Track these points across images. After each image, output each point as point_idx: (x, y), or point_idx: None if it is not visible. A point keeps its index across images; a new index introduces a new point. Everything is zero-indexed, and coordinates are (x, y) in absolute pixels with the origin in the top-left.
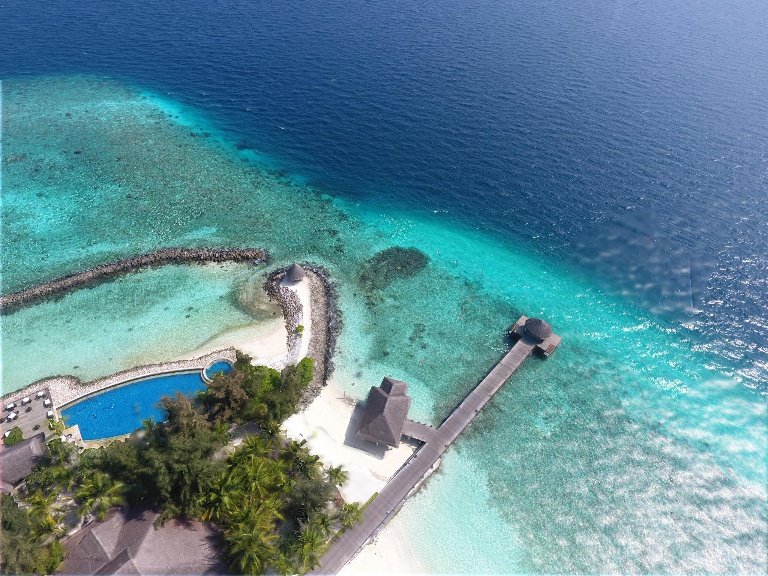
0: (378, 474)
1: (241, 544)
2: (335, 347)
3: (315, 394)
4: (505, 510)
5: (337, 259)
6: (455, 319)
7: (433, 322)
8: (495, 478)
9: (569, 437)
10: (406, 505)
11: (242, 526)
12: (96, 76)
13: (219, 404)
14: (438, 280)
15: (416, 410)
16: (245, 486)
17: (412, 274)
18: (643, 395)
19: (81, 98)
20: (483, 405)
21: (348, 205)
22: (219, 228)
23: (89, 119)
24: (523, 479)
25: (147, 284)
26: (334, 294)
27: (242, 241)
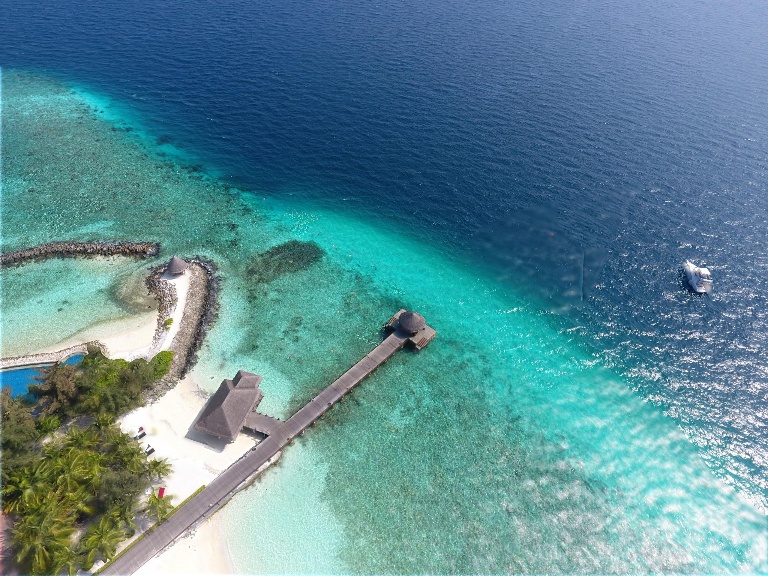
0: (212, 467)
1: (21, 536)
2: (204, 340)
3: (169, 387)
4: (337, 503)
5: (229, 253)
6: (335, 313)
7: (312, 316)
8: (335, 471)
9: (422, 430)
10: (235, 498)
11: (30, 518)
12: (29, 71)
13: (46, 396)
14: (328, 274)
15: (271, 403)
16: (52, 479)
17: (303, 268)
18: (511, 388)
19: (8, 93)
20: (338, 398)
21: (256, 199)
22: (116, 222)
23: (11, 114)
24: (364, 472)
25: (27, 278)
26: (217, 288)
27: (136, 235)
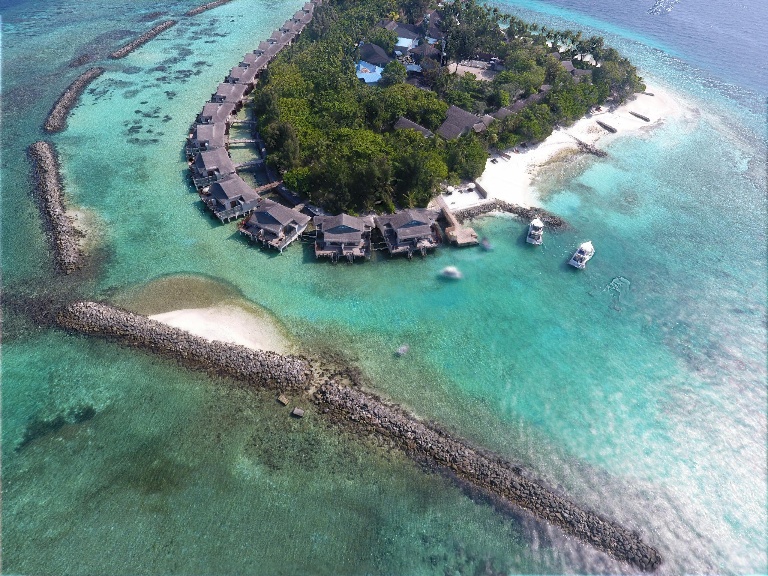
0: None
1: None
2: None
3: None
4: None
5: None
6: None
7: None
8: None
9: None
10: None
11: None
12: None
13: None
14: None
15: None
16: None
17: None
18: (514, 4)
19: None
20: None
21: None
22: None
23: None
24: None
25: None
26: None
27: None
